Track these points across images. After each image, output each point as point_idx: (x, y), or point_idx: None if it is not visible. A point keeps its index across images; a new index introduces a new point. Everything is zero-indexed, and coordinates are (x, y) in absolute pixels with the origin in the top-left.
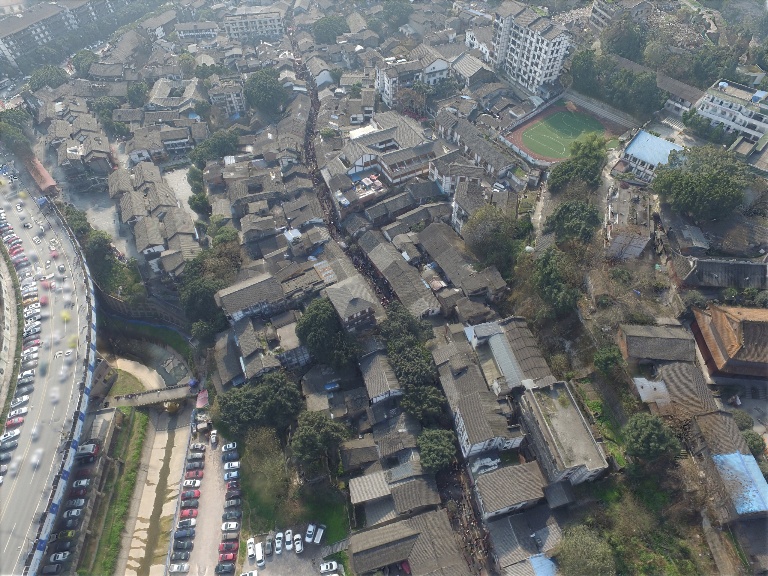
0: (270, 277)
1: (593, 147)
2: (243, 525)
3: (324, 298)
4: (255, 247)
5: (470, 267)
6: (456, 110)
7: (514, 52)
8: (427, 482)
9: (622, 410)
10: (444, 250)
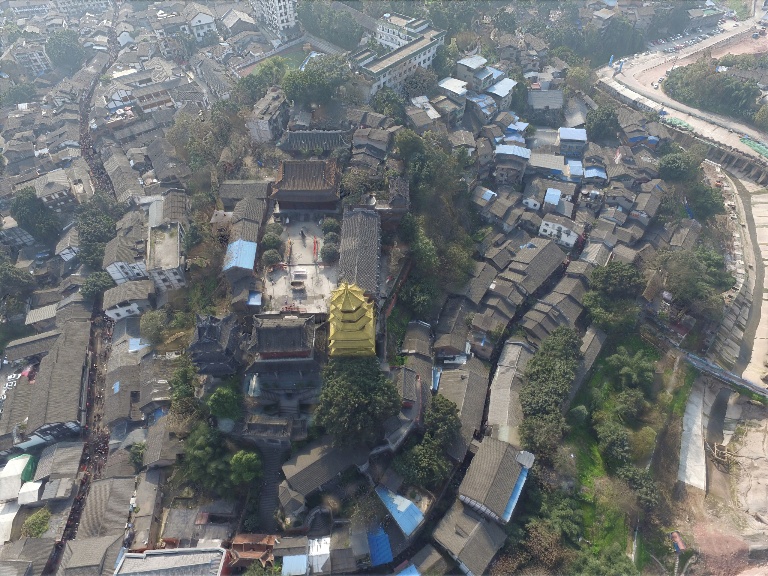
0: (0, 178)
1: (270, 66)
2: None
3: (33, 187)
4: (15, 166)
5: (171, 164)
6: (211, 54)
7: (262, 4)
8: (84, 306)
9: None
10: (159, 155)
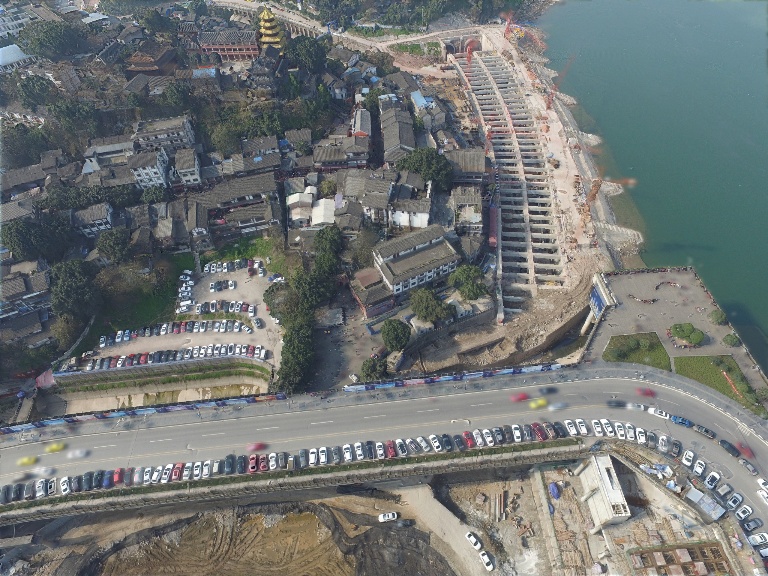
0: None
1: None
2: (166, 321)
3: (3, 227)
4: None
5: (33, 165)
6: None
7: None
8: None
9: (164, 108)
10: (6, 179)
